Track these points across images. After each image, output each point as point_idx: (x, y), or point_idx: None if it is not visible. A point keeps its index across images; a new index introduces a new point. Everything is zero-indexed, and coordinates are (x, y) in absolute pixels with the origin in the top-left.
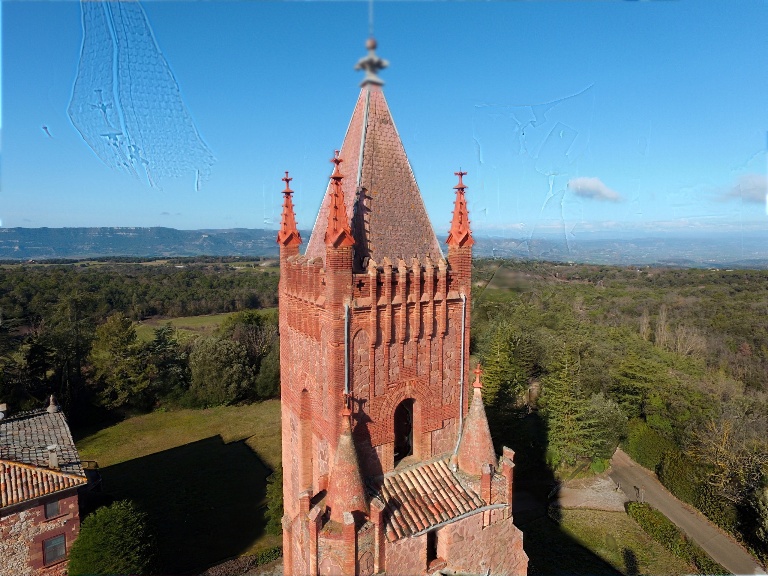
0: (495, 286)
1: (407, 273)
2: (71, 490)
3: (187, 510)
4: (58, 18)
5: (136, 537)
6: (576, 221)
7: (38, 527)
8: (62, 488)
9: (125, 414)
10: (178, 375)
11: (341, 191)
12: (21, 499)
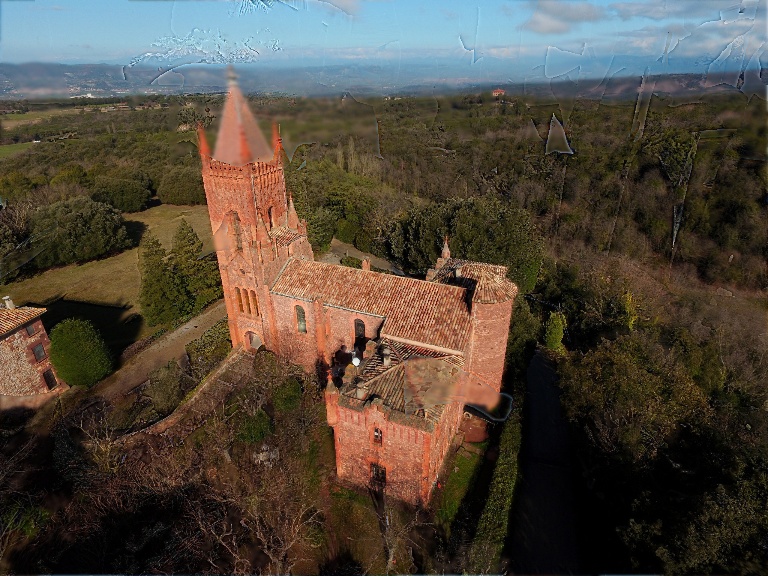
0: None
1: None
2: (37, 317)
3: None
4: (271, 147)
5: (93, 331)
6: None
7: (27, 341)
8: (35, 315)
9: None
10: None
11: None
12: (15, 325)
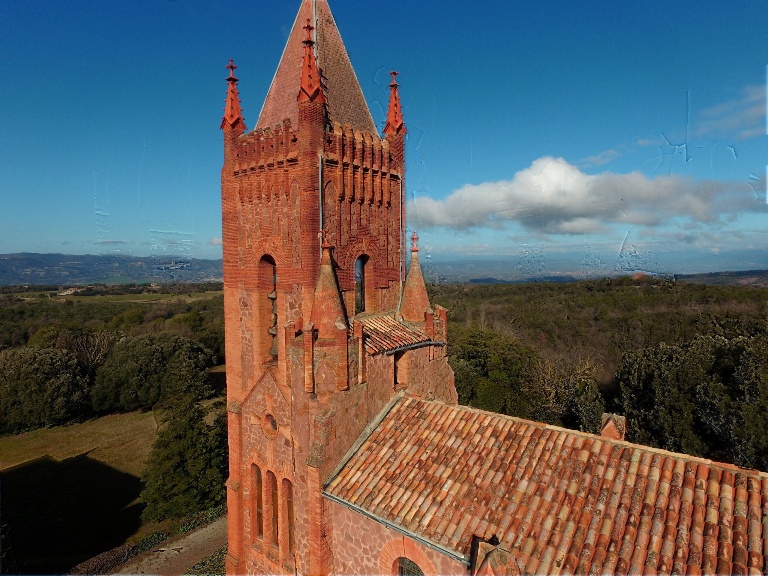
0: None
1: None
2: None
3: (23, 528)
4: None
5: None
6: (426, 208)
7: None
8: None
9: None
10: None
11: (313, 55)
12: None
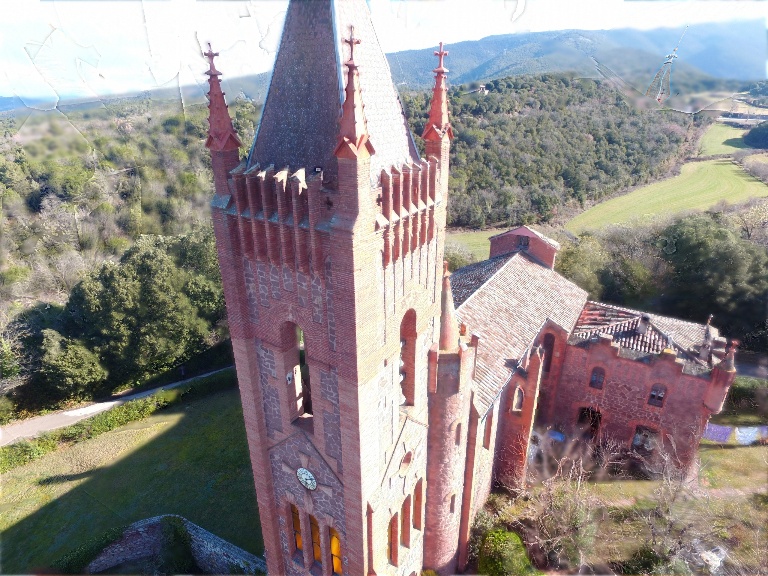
0: None
1: None
2: None
3: None
4: None
5: None
6: None
7: None
8: None
9: None
10: None
11: None
12: None
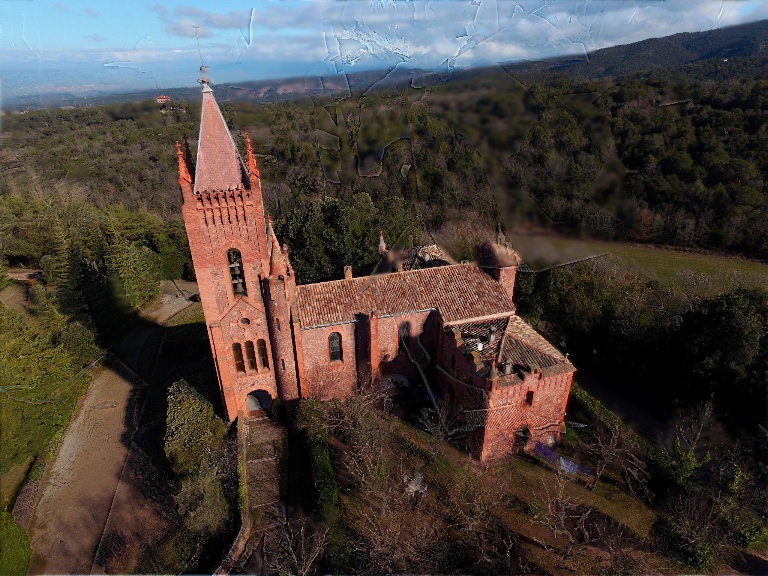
0: (64, 182)
1: None
2: None
3: None
4: None
5: None
6: (57, 107)
7: None
8: None
9: None
10: None
11: None
12: None
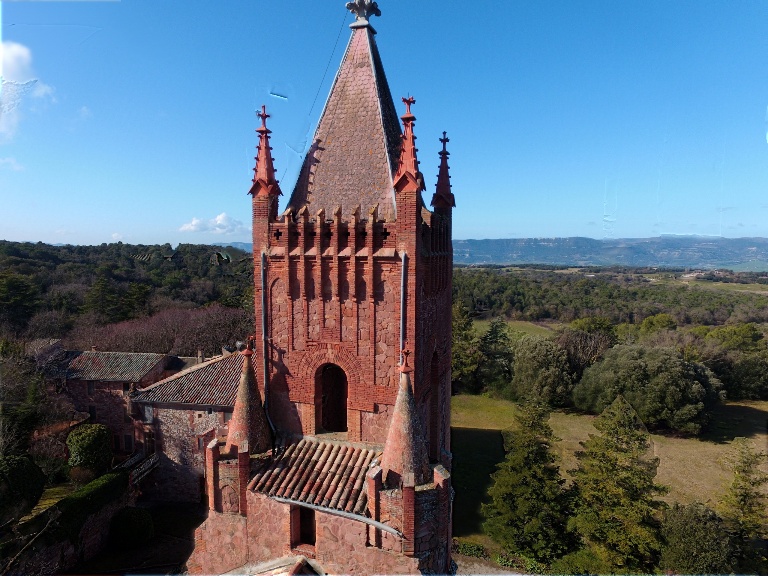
0: None
1: (328, 224)
2: None
3: None
4: None
5: None
6: None
7: None
8: None
9: (458, 390)
10: (503, 366)
11: (264, 144)
12: None
